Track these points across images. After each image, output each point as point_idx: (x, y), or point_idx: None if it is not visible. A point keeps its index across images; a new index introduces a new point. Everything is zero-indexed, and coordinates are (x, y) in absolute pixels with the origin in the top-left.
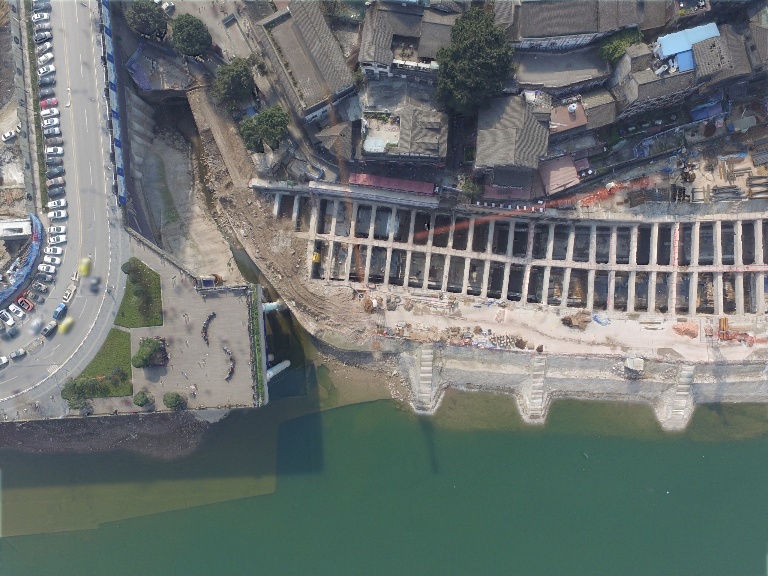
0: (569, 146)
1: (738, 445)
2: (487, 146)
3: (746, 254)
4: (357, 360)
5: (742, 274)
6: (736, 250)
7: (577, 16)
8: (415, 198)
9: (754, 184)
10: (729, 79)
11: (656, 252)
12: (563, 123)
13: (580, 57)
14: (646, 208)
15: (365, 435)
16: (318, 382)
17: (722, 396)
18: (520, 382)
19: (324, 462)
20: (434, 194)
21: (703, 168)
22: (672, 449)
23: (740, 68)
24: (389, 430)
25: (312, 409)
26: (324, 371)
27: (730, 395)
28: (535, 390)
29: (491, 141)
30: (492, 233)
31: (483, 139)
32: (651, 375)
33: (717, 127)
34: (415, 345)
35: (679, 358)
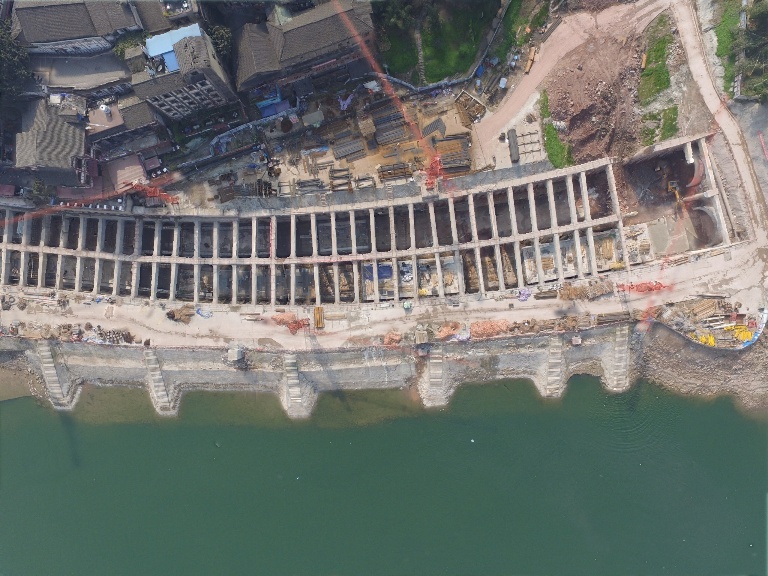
0: (134, 146)
1: (361, 430)
2: (21, 148)
3: (380, 244)
4: None
5: (336, 264)
6: (332, 241)
7: (73, 21)
8: (3, 200)
9: (335, 177)
10: (261, 76)
11: (255, 245)
12: (101, 124)
13: (108, 60)
14: (240, 203)
15: (11, 432)
16: None
17: (339, 383)
18: (144, 376)
19: None
20: (18, 196)
21: (287, 163)
22: (301, 436)
23: (266, 66)
24: (30, 426)
25: None
26: None
27: (346, 382)
28: (156, 383)
29: (23, 143)
30: (100, 232)
31: (19, 142)
32: (261, 365)
33: (294, 122)
34: (33, 343)
35: (279, 347)
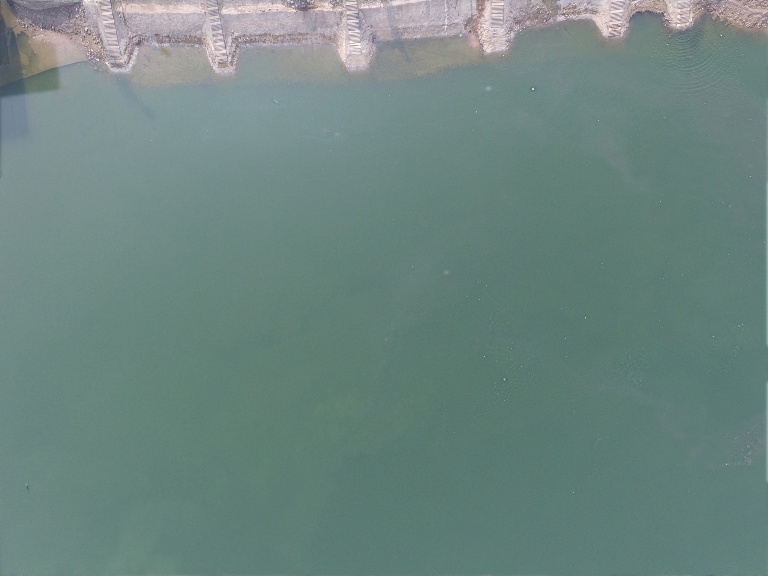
0: None
1: (421, 81)
2: None
3: None
4: (50, 21)
5: None
6: None
7: None
8: None
9: None
10: None
11: None
12: None
13: None
14: None
15: (67, 100)
16: (19, 49)
17: (398, 29)
18: (202, 26)
19: (28, 127)
20: None
21: None
22: (359, 91)
23: None
24: (87, 91)
25: (15, 77)
26: (24, 39)
27: (406, 27)
28: (215, 31)
29: None
30: None
31: None
32: (321, 4)
33: None
34: None
35: None
